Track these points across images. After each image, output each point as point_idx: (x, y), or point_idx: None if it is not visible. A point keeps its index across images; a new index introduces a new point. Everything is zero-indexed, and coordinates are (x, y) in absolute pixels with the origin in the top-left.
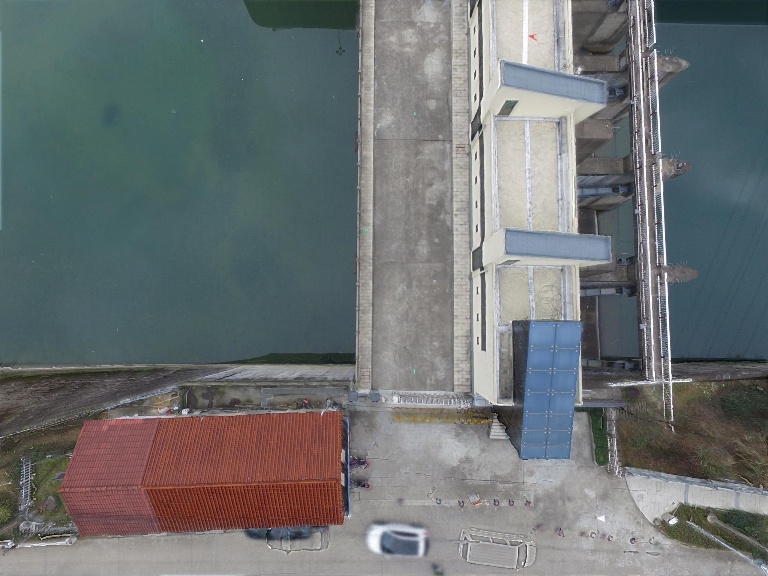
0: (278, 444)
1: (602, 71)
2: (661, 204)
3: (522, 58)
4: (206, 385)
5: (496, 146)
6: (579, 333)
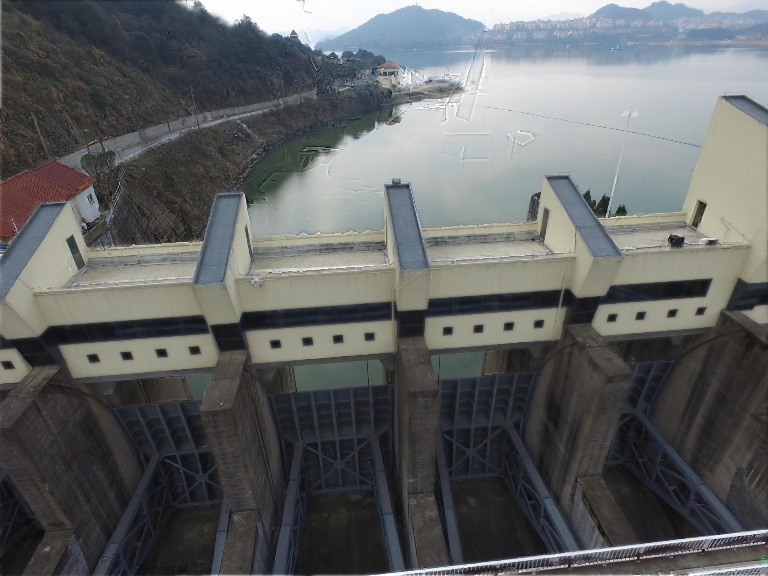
0: (8, 209)
1: (419, 561)
2: None
3: (292, 268)
4: (96, 226)
5: (194, 262)
6: None
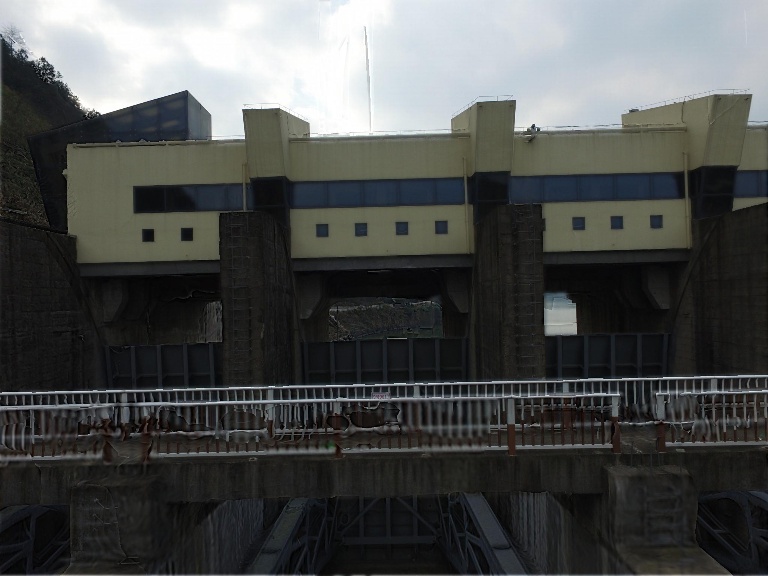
0: None
1: None
2: (417, 402)
3: None
4: None
5: None
6: (175, 95)
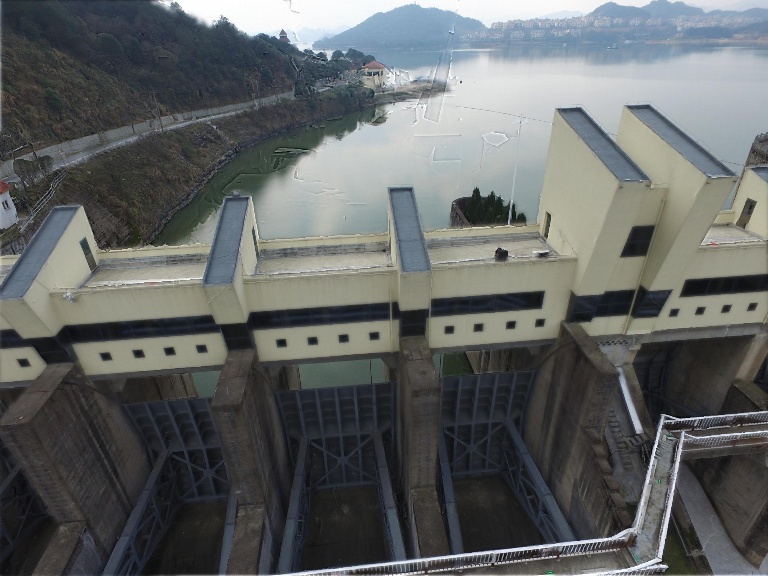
0: None
1: (227, 573)
2: None
3: (129, 280)
4: (4, 232)
5: None
6: None
